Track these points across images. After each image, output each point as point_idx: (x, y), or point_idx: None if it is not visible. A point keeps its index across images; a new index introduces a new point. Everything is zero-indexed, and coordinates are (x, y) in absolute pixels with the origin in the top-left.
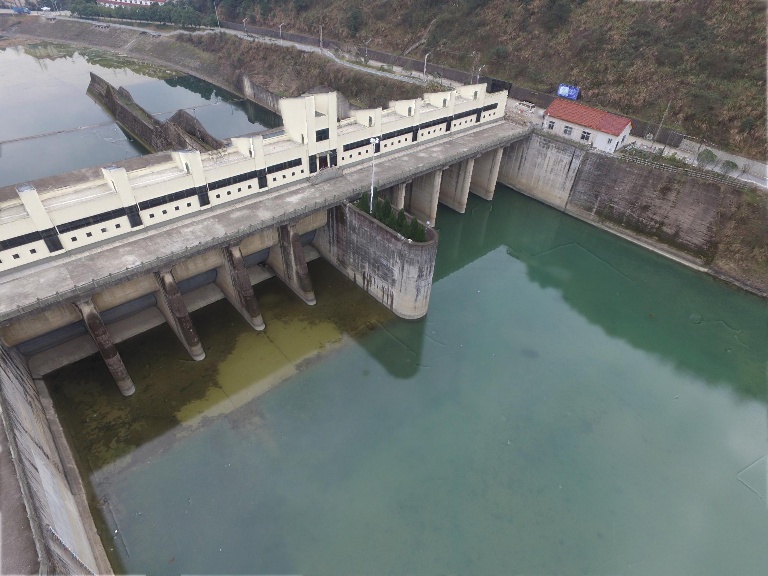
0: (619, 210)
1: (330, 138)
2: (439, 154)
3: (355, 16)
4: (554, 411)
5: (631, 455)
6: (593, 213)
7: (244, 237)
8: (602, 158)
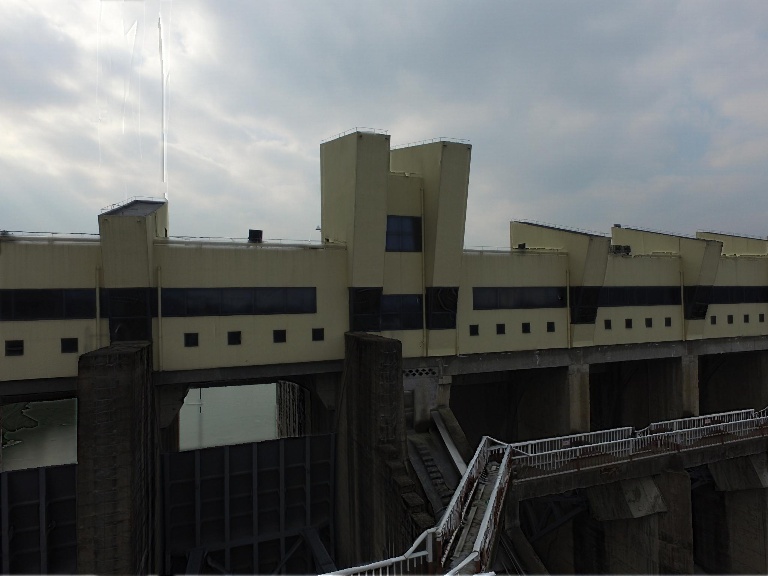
0: None
1: None
2: None
3: None
4: (268, 420)
5: (253, 409)
6: None
7: None
8: None
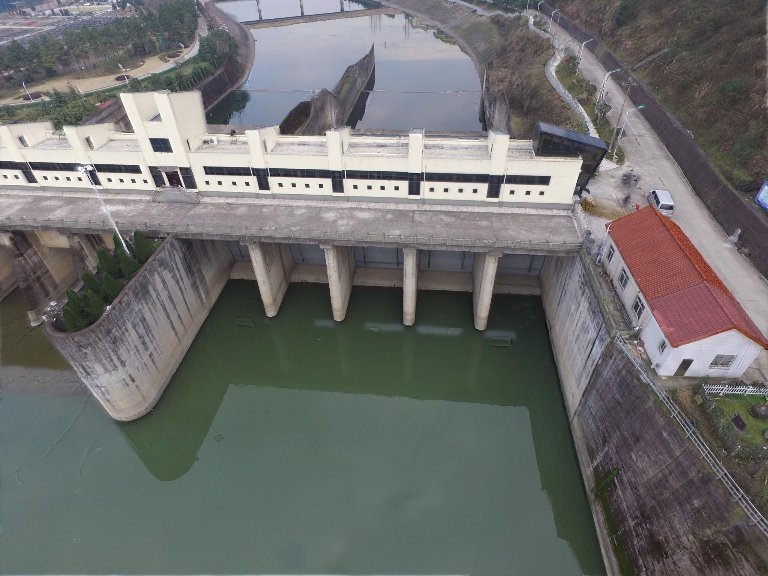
0: (620, 503)
1: (174, 152)
2: (349, 223)
3: (623, 5)
4: None
5: None
6: (592, 467)
7: (6, 227)
8: (631, 373)
